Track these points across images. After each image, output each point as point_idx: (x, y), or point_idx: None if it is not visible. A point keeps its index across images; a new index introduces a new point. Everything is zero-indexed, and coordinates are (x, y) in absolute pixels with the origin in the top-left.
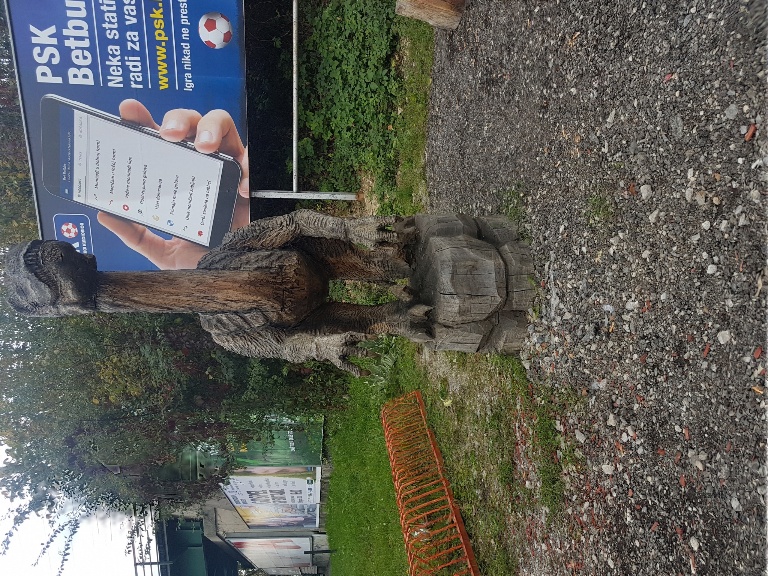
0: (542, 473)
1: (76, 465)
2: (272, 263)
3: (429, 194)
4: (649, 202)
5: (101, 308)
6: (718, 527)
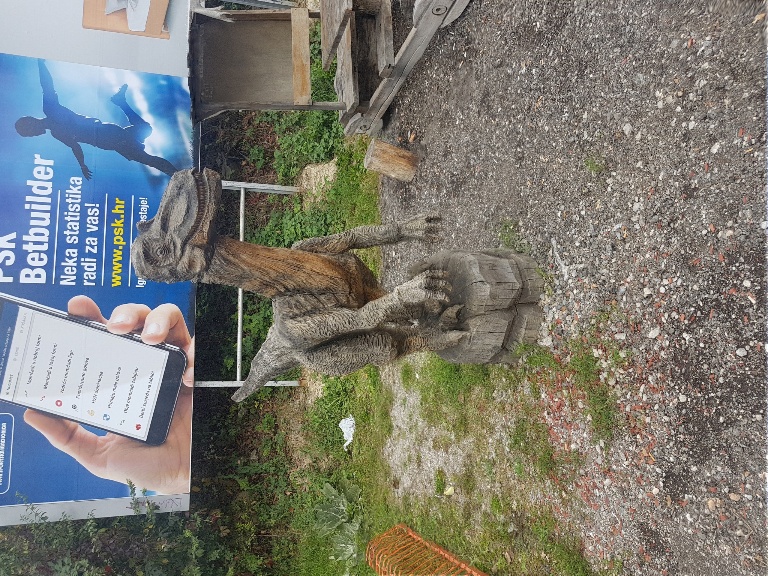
0: (592, 401)
1: None
2: (338, 258)
3: None
4: (631, 136)
5: (214, 262)
6: (759, 254)
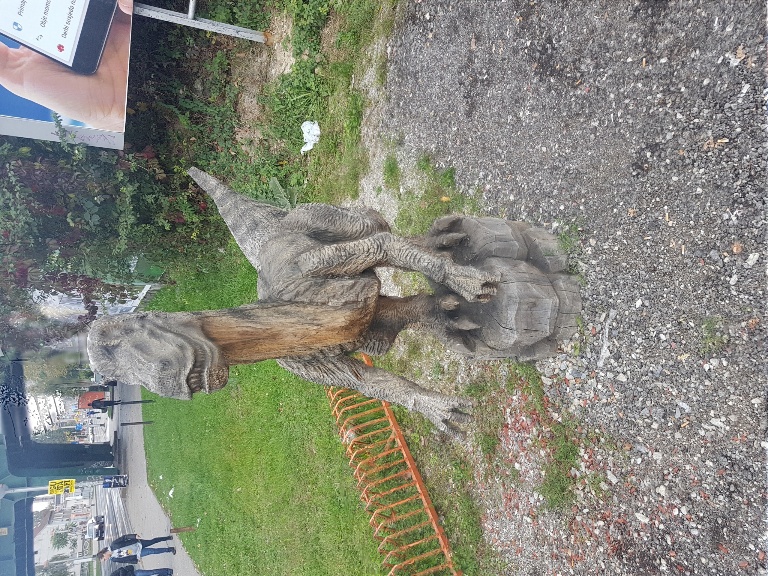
0: (552, 479)
1: None
2: (358, 296)
3: (388, 98)
4: None
5: None
6: None
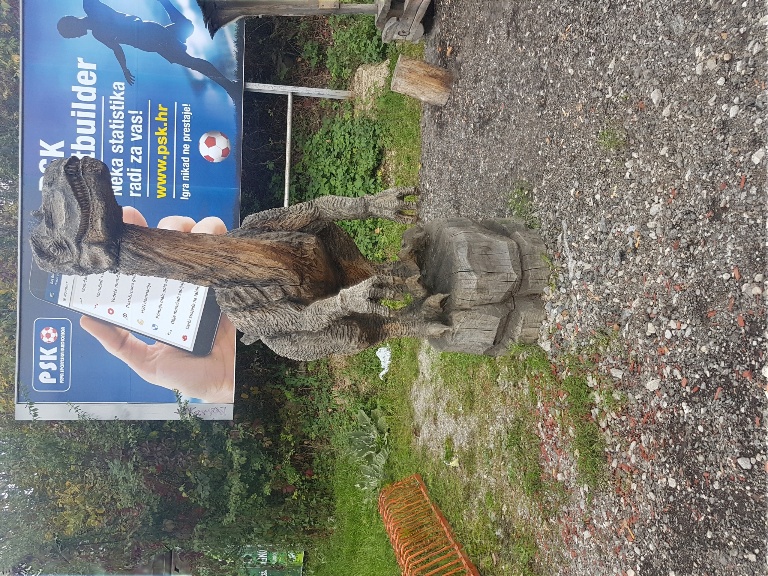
0: (578, 439)
1: (36, 559)
2: (292, 239)
3: None
4: (660, 106)
5: (123, 259)
6: None
